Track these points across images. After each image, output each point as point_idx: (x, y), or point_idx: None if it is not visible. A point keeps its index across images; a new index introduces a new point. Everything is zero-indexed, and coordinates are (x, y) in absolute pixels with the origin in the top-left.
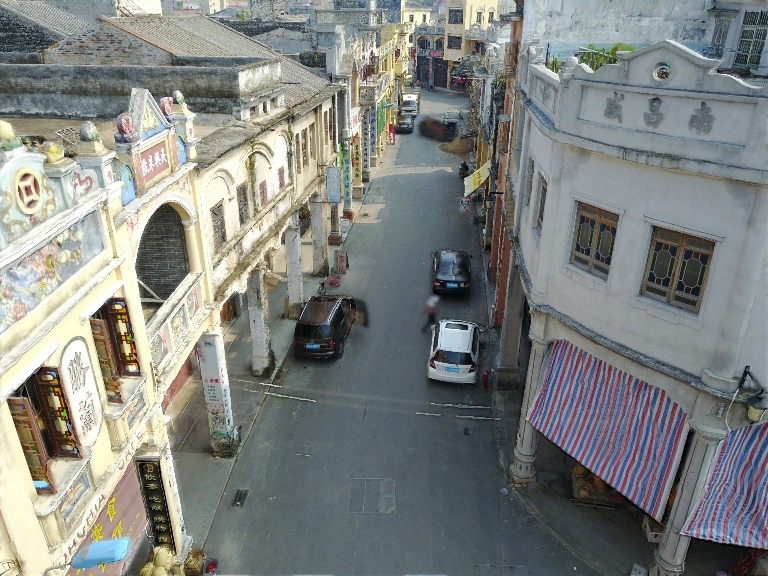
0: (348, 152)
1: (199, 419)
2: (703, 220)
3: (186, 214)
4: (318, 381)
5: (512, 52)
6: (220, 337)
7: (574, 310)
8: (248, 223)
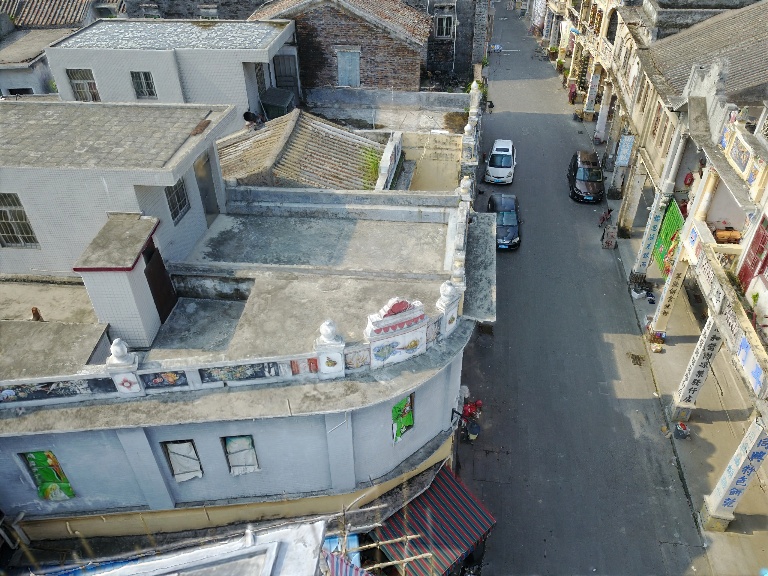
0: None
1: None
2: None
3: None
4: None
5: None
6: None
7: None
8: None
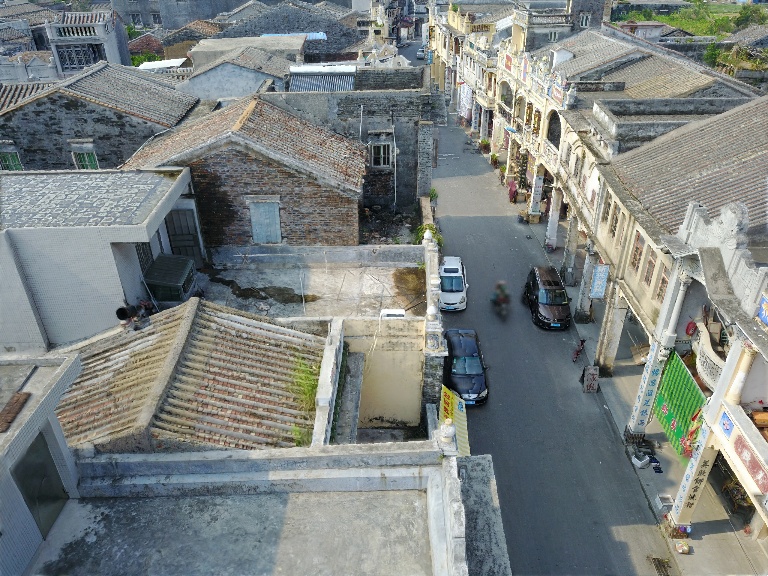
0: None
1: (576, 257)
2: None
3: None
4: None
5: None
6: None
7: None
8: None
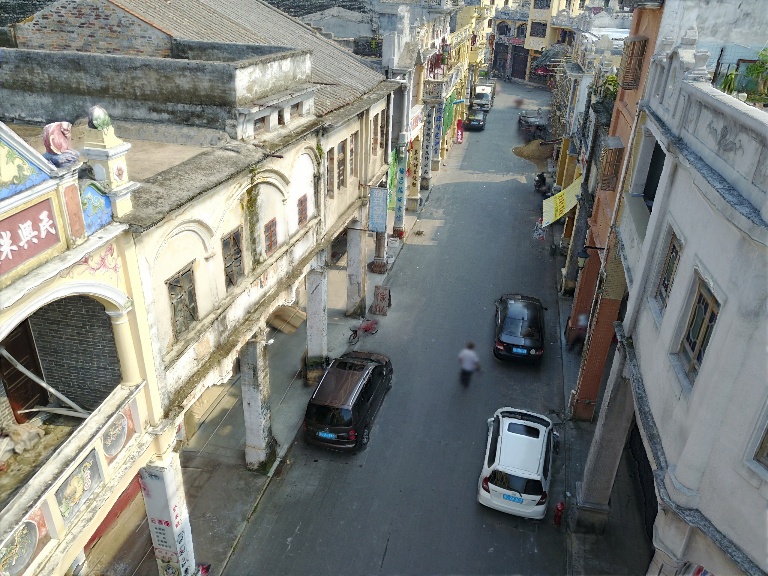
0: (404, 160)
1: None
2: None
3: (109, 303)
4: (329, 486)
5: (636, 53)
6: (174, 463)
7: (755, 545)
8: (241, 283)
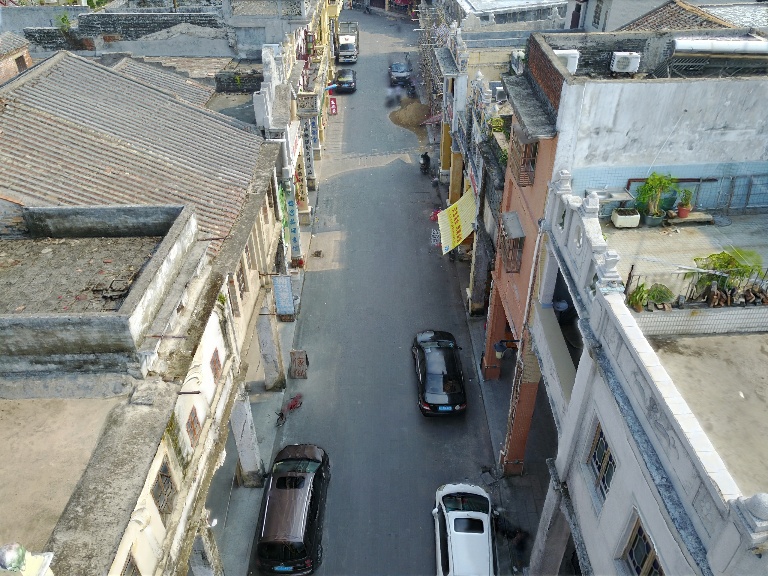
0: (291, 193)
1: None
2: None
3: None
4: None
5: (528, 154)
6: None
7: None
8: (176, 503)
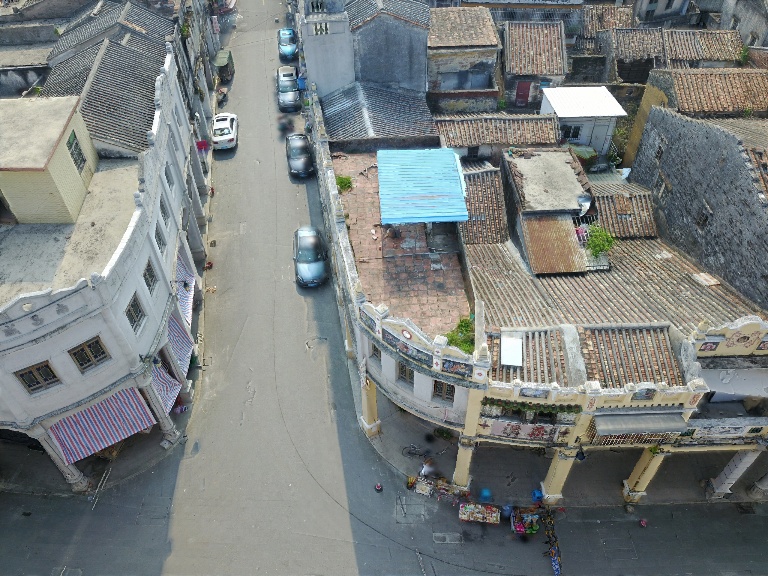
0: None
1: None
2: (88, 333)
3: None
4: None
5: None
6: None
7: (55, 406)
8: None
